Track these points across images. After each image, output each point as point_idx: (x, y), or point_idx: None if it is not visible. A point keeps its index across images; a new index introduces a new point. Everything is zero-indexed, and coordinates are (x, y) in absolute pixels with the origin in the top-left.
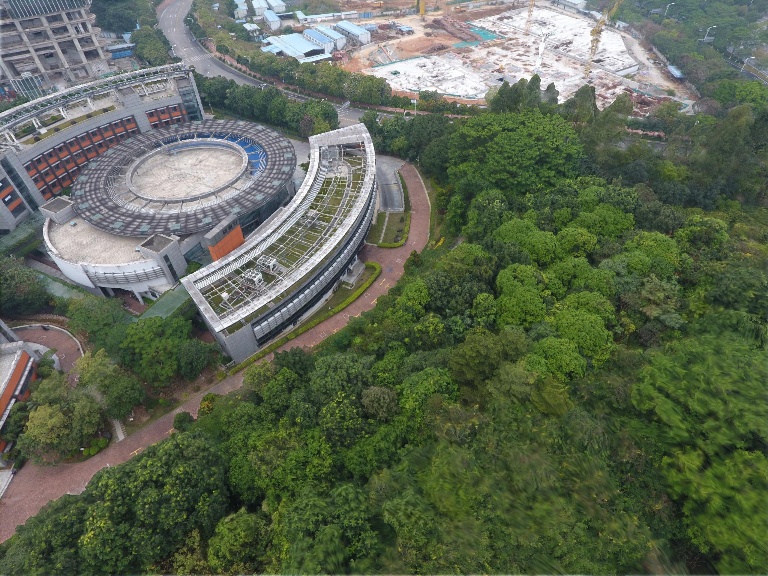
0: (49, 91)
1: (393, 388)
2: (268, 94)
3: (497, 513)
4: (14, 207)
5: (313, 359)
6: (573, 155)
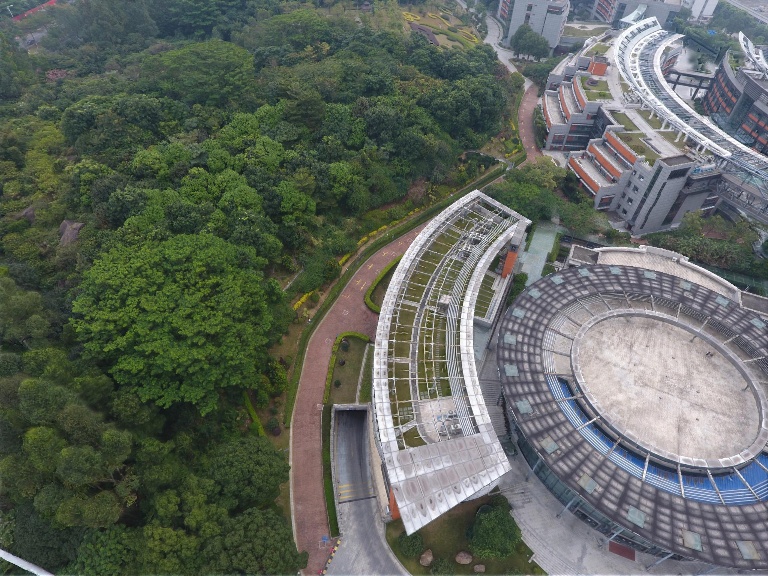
0: None
1: None
2: None
3: (321, 65)
4: None
5: None
6: None
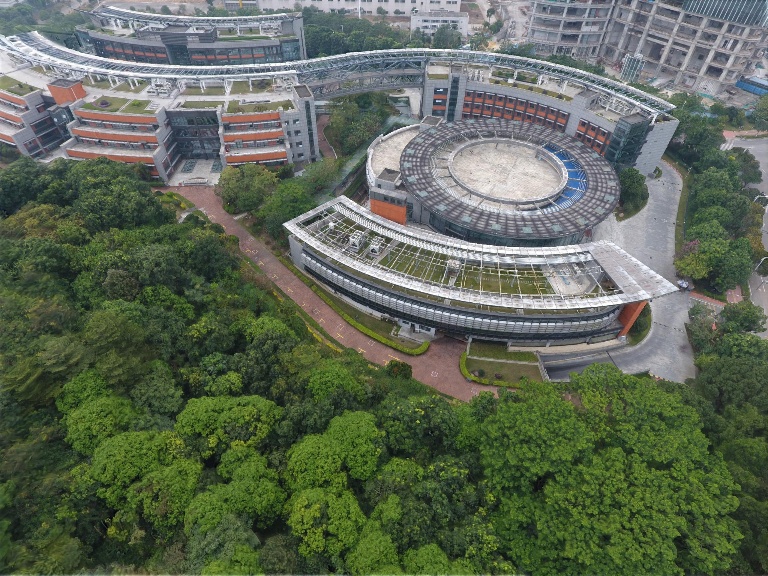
0: (649, 80)
1: (137, 298)
2: (723, 198)
3: None
4: (438, 109)
5: (215, 267)
6: (588, 569)
